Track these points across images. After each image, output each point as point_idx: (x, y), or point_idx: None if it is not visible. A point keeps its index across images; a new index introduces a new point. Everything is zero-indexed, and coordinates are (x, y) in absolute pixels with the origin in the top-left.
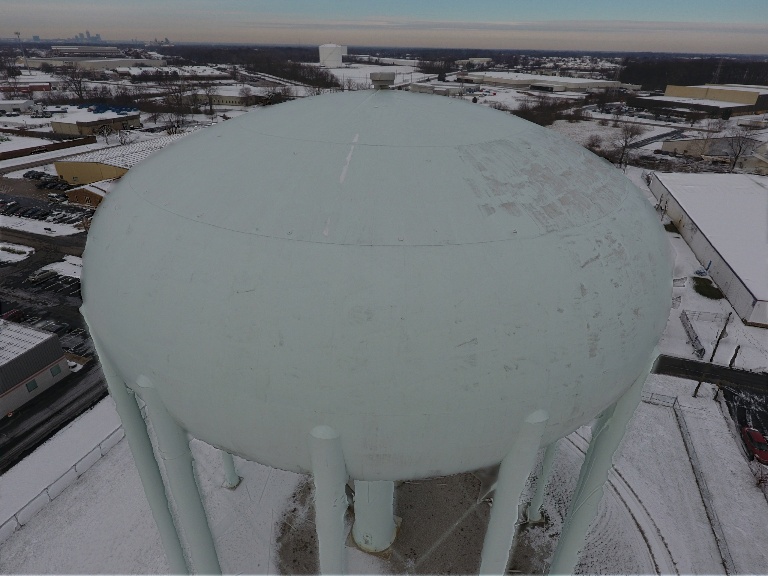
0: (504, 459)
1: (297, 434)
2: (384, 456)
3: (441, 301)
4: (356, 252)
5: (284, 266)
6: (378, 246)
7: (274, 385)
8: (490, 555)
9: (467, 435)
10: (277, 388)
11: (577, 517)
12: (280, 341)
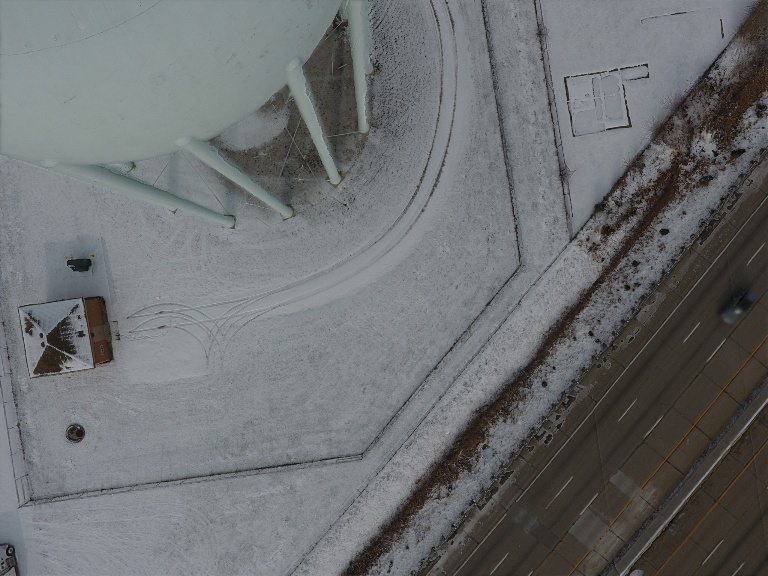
0: (287, 84)
1: (168, 147)
2: (221, 129)
3: (198, 42)
4: (117, 35)
5: (78, 71)
6: (128, 21)
7: (137, 138)
8: (306, 119)
9: (259, 97)
10: (140, 138)
11: (354, 53)
12: (121, 118)
